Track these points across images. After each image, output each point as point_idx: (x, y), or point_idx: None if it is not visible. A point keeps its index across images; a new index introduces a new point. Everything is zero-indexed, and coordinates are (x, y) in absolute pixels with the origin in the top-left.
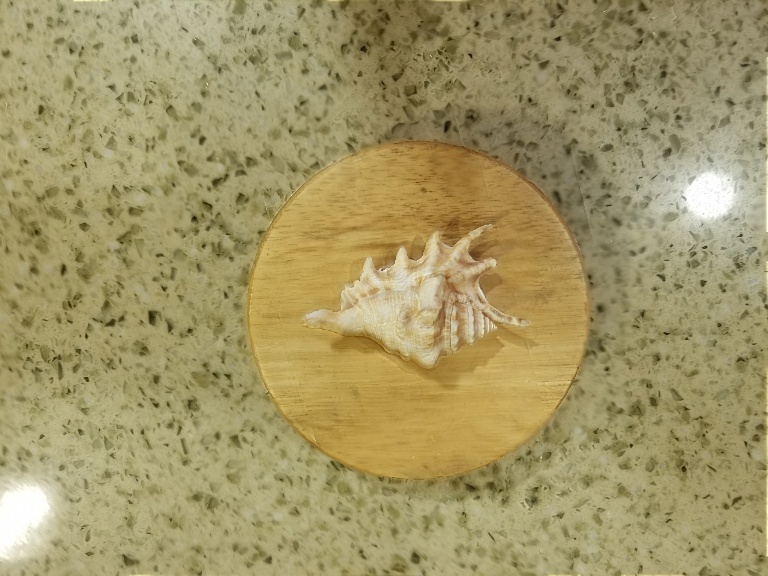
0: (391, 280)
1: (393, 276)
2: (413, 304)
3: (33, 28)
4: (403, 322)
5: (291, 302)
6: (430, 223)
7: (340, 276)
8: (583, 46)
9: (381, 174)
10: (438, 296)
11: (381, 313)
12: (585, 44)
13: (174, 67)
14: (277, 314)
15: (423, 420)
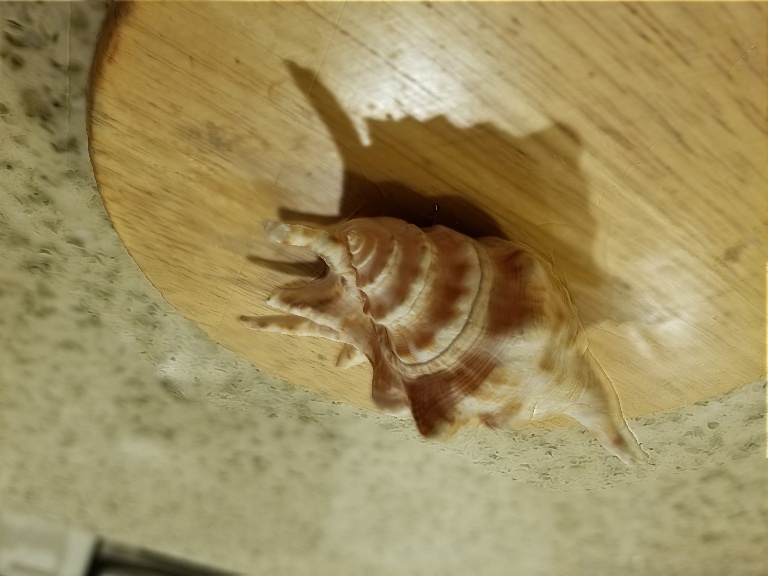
0: None
1: None
2: None
3: (555, 491)
4: None
5: (629, 383)
6: None
7: None
8: (7, 229)
9: (364, 392)
10: (406, 398)
11: None
12: (3, 229)
13: (486, 436)
14: (664, 386)
15: (703, 115)
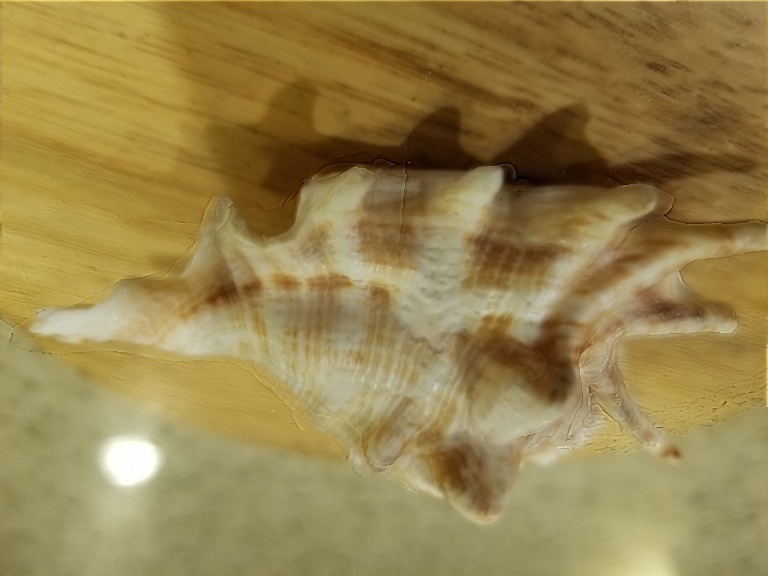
0: (406, 270)
1: (419, 249)
2: (437, 412)
3: None
4: (379, 468)
5: (4, 101)
6: (655, 87)
7: (227, 104)
8: None
9: None
10: None
11: (322, 390)
12: None
13: None
14: None
15: None
